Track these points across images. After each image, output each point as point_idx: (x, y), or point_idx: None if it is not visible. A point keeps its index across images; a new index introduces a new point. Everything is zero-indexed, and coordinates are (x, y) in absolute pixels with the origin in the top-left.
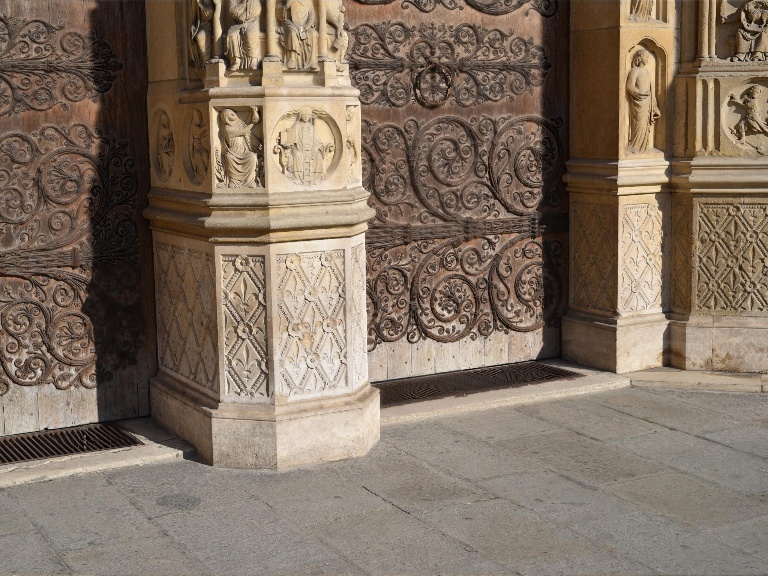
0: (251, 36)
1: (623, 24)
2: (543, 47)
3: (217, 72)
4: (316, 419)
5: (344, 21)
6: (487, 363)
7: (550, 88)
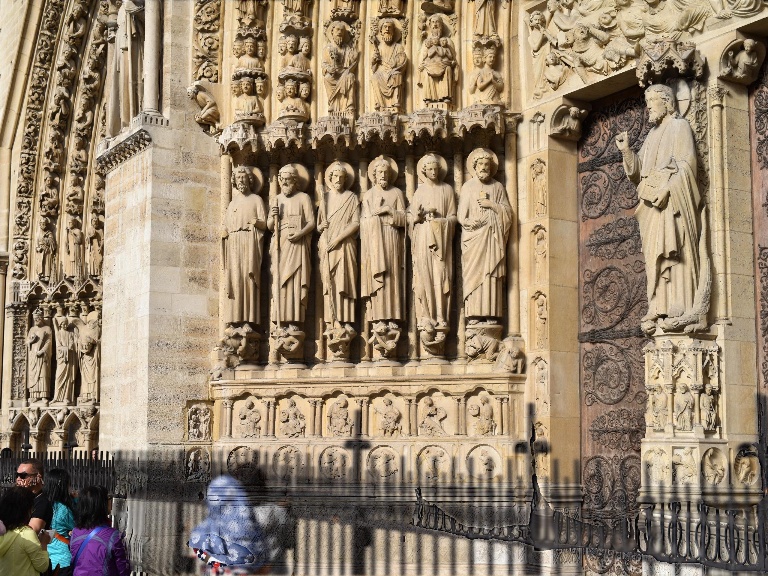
0: None
1: None
2: None
3: None
4: None
5: None
6: None
7: None
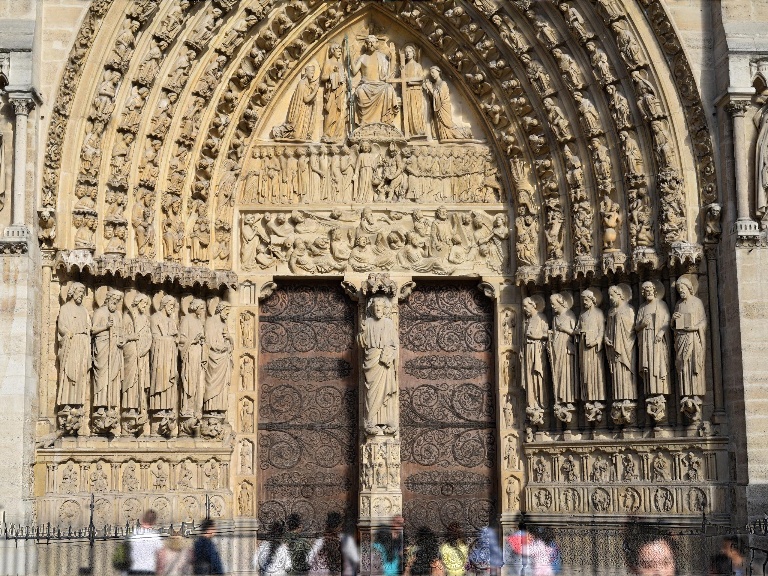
0: (370, 479)
1: (503, 471)
2: (489, 477)
3: (363, 487)
4: None
5: (418, 471)
6: None
7: (492, 490)
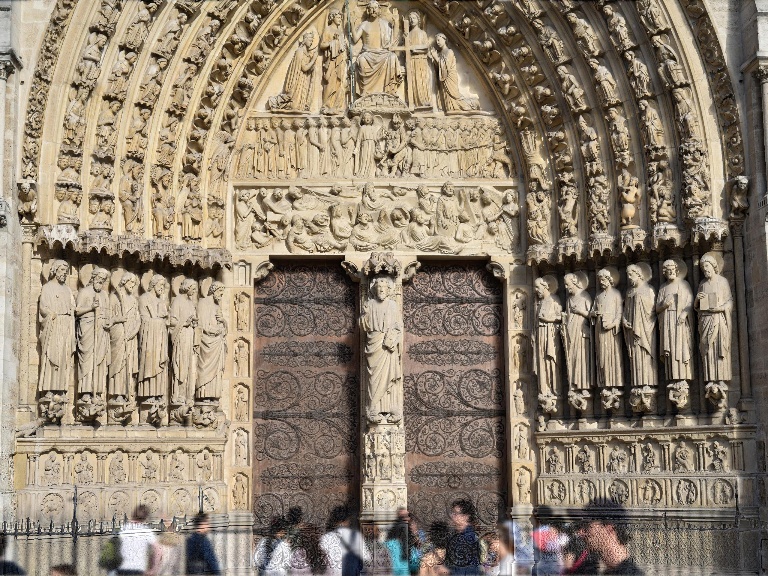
0: (373, 470)
1: (513, 462)
2: (498, 468)
3: (365, 479)
4: (386, 574)
5: (423, 462)
6: (477, 575)
7: (501, 482)
